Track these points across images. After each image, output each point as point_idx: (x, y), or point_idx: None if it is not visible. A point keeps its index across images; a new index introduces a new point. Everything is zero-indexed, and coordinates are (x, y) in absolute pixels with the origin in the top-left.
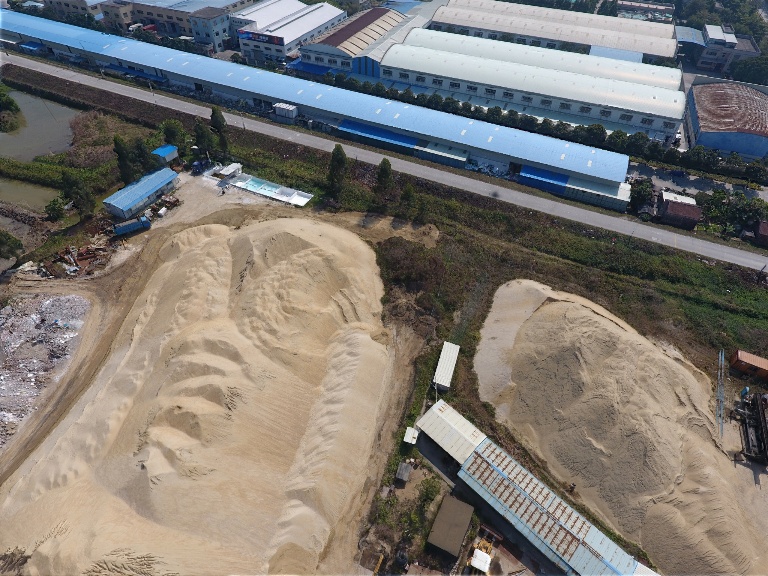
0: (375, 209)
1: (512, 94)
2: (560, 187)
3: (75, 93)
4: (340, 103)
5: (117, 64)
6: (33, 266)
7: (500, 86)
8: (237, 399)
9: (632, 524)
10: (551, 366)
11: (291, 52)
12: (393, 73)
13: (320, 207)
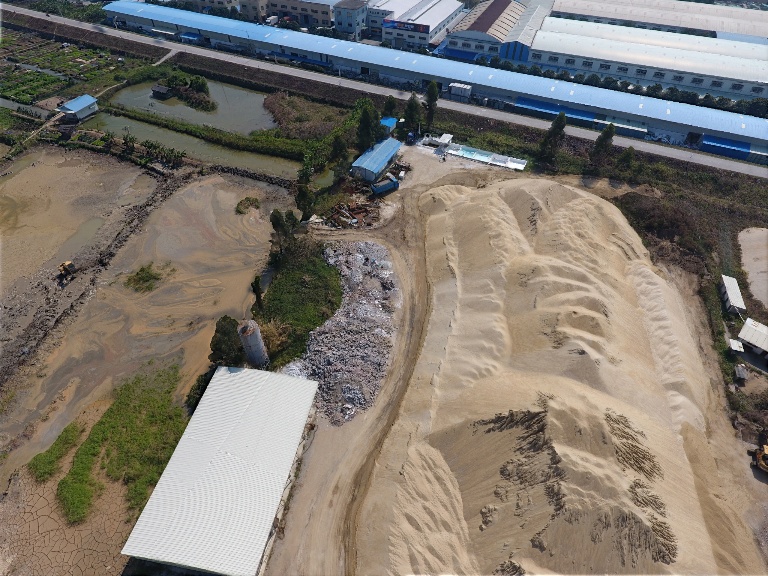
0: (590, 172)
1: (663, 74)
2: (743, 153)
3: (255, 77)
4: (513, 82)
5: (279, 51)
6: (319, 219)
7: (652, 66)
8: (606, 309)
9: None
10: None
11: (432, 40)
12: (542, 56)
13: (538, 171)
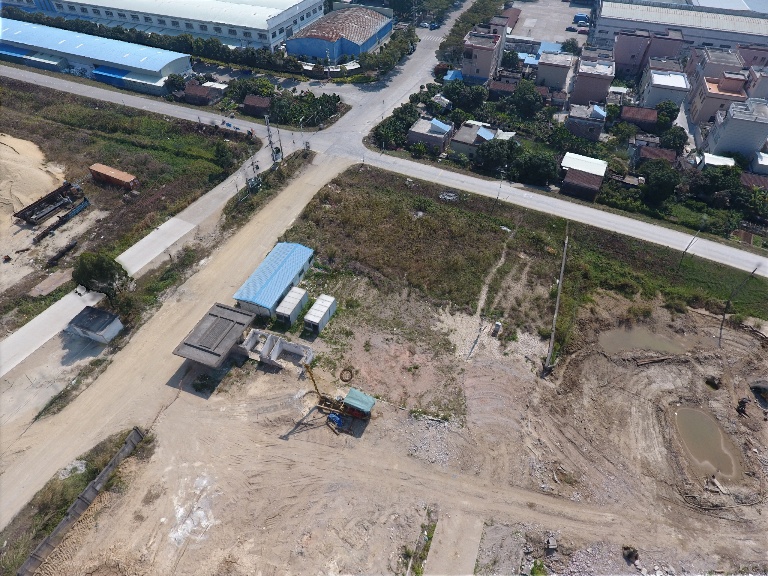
0: None
1: (150, 18)
2: (119, 80)
3: None
4: None
5: None
6: None
7: (138, 11)
8: None
9: None
10: None
11: None
12: (63, 6)
13: None
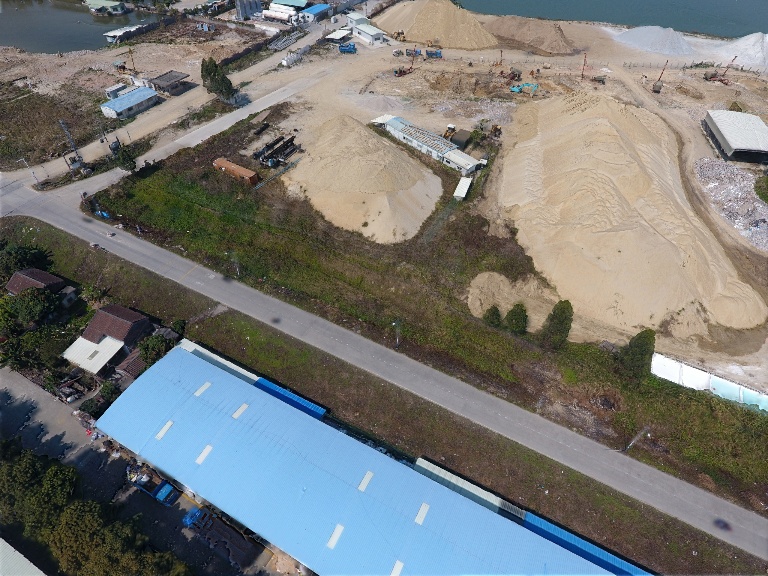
0: None
1: None
2: None
3: None
4: None
5: None
6: None
7: None
8: None
9: None
10: (401, 158)
11: None
12: None
13: None
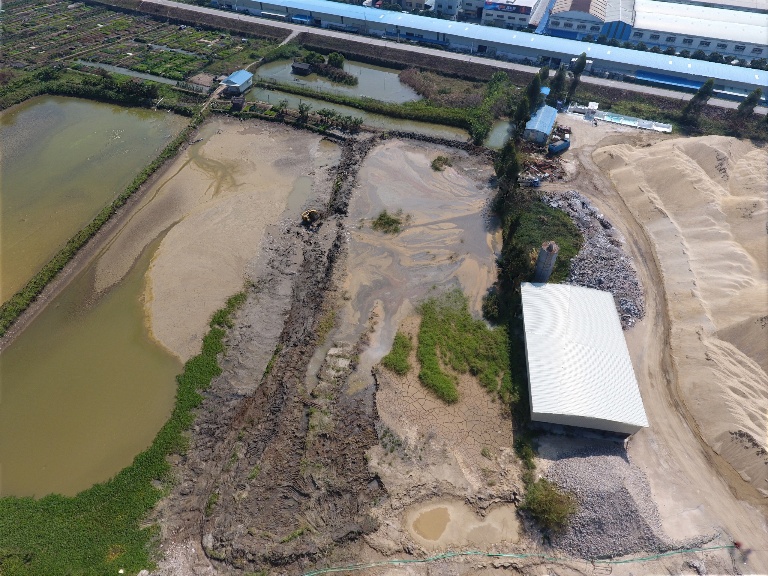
0: (732, 133)
1: (761, 49)
2: None
3: (383, 54)
4: (632, 57)
5: (394, 31)
6: None
7: (752, 43)
8: None
9: None
10: None
11: (530, 21)
12: (644, 35)
13: (684, 133)
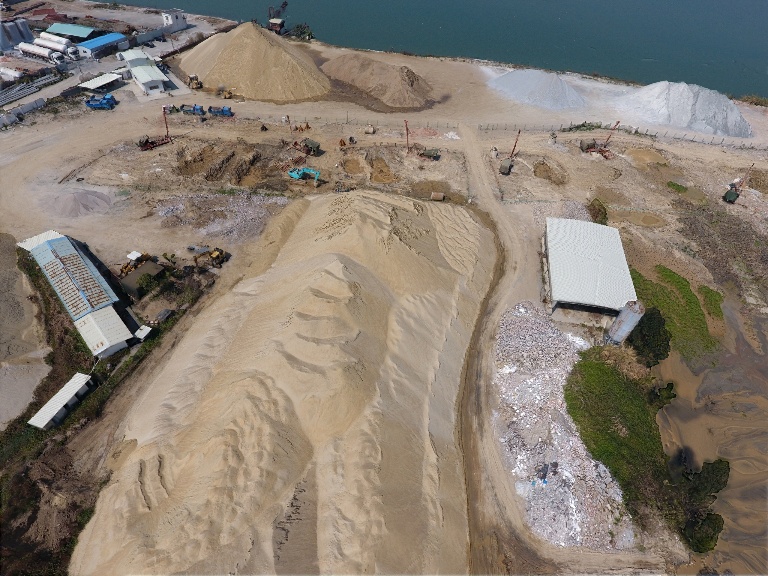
0: None
1: None
2: None
3: None
4: None
5: None
6: None
7: None
8: None
9: (9, 273)
10: None
11: None
12: None
13: None
